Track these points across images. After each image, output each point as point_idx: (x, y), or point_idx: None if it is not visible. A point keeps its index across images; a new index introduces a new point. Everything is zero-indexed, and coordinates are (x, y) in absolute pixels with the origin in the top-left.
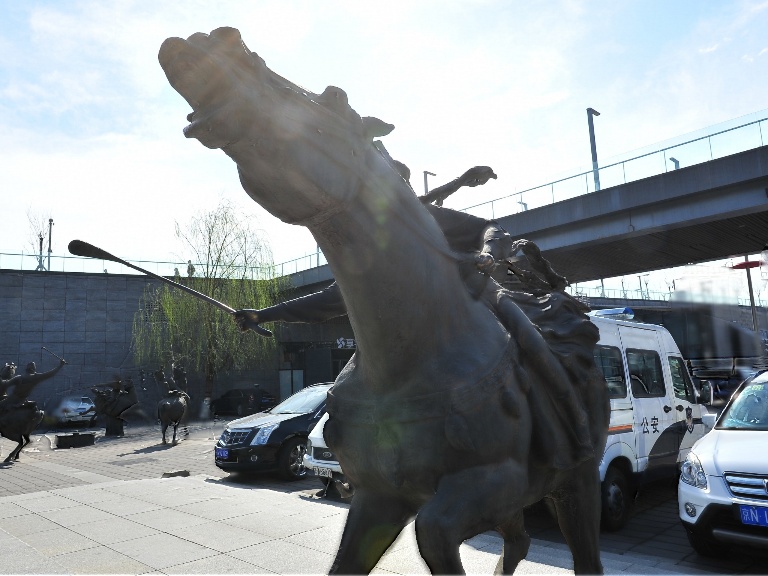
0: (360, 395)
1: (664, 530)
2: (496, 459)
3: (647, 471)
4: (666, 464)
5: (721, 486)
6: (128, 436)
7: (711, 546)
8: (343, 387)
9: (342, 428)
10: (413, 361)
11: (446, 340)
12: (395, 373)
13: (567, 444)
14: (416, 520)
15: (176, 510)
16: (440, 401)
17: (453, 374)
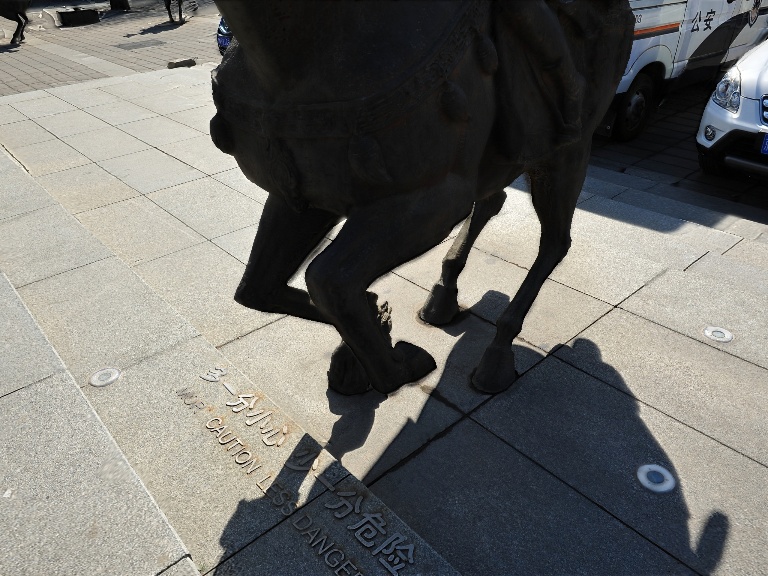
0: (245, 89)
1: (679, 142)
2: (425, 183)
3: (682, 76)
4: (707, 66)
5: (754, 111)
6: (134, 11)
7: (720, 167)
8: (226, 72)
9: (231, 130)
10: (306, 49)
11: (359, 11)
12: (281, 67)
13: (547, 126)
14: (306, 273)
15: (169, 118)
16: (342, 116)
17: (363, 73)
